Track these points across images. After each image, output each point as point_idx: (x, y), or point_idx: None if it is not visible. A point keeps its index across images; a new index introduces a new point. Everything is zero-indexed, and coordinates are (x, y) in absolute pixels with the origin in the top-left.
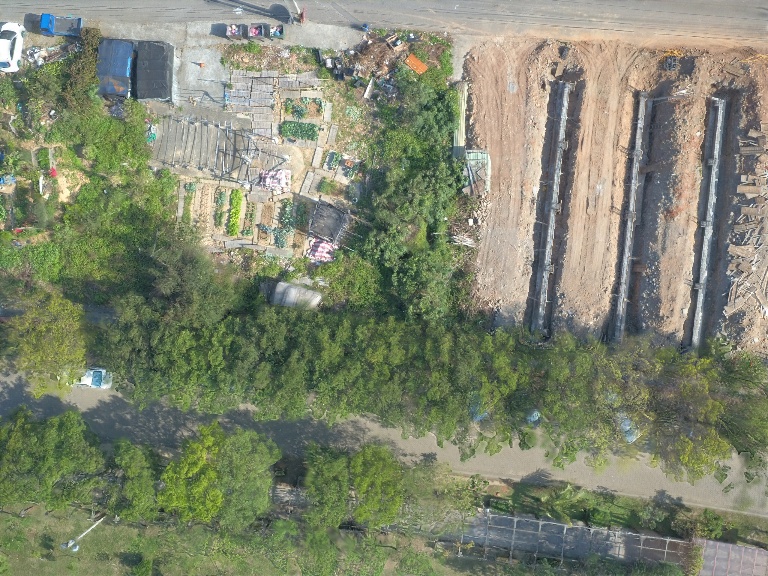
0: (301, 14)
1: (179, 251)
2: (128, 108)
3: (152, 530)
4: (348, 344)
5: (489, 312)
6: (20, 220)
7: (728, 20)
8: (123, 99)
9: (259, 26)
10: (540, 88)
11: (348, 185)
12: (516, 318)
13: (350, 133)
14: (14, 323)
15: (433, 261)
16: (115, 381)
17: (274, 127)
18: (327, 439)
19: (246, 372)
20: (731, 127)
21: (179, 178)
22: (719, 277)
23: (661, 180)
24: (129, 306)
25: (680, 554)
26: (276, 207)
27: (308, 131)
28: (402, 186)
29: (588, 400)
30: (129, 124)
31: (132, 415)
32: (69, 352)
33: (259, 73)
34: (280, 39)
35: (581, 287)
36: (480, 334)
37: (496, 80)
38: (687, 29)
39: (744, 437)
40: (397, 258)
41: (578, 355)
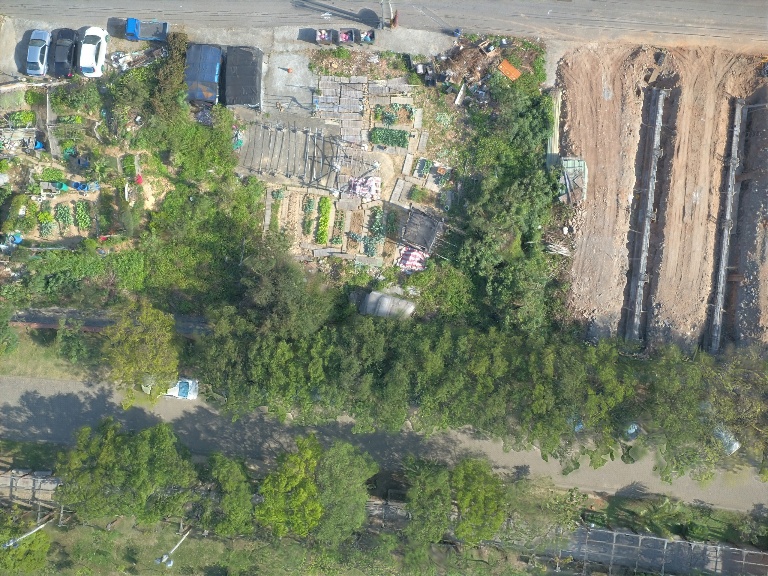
0: (393, 19)
1: (274, 260)
2: (217, 114)
3: (238, 544)
4: (448, 355)
5: (583, 322)
6: (104, 228)
7: None
8: (210, 105)
9: (349, 31)
10: (635, 95)
11: (439, 193)
12: (611, 328)
13: (441, 140)
14: (105, 333)
15: (529, 270)
16: (200, 392)
17: (363, 134)
18: (417, 451)
19: (347, 384)
20: None
21: (266, 185)
22: None
23: (759, 188)
24: (223, 316)
25: None
26: (366, 215)
27: (399, 138)
28: (497, 194)
29: (701, 413)
30: (216, 130)
31: (218, 426)
32: (163, 363)
33: (348, 79)
34: (369, 44)
35: (677, 297)
36: (581, 345)
37: (591, 86)
38: None
39: None
40: (492, 267)
41: (686, 367)
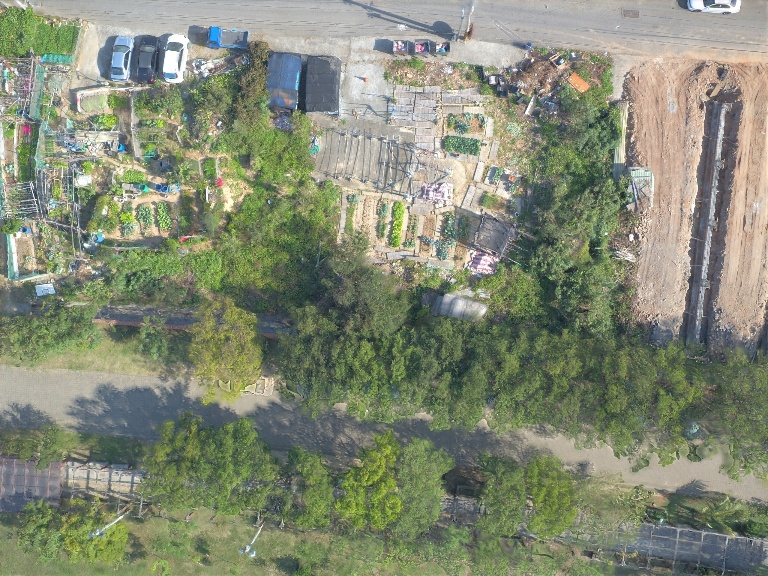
0: (469, 32)
1: (355, 262)
2: (297, 121)
3: (309, 536)
4: (523, 356)
5: (647, 326)
6: (184, 229)
7: None
8: (289, 111)
9: (425, 43)
10: (698, 108)
11: (509, 199)
12: (673, 332)
13: (511, 149)
14: (190, 330)
15: (597, 275)
16: (275, 389)
17: (437, 141)
18: (485, 448)
19: (428, 382)
20: None
21: (341, 190)
22: None
23: None
24: (306, 315)
25: None
26: (438, 220)
27: (471, 146)
28: (566, 201)
29: None
30: (294, 136)
31: (291, 422)
32: (248, 360)
33: (422, 88)
34: (443, 56)
35: (738, 303)
36: (649, 348)
37: (656, 99)
38: None
39: None
40: (562, 272)
41: (753, 370)
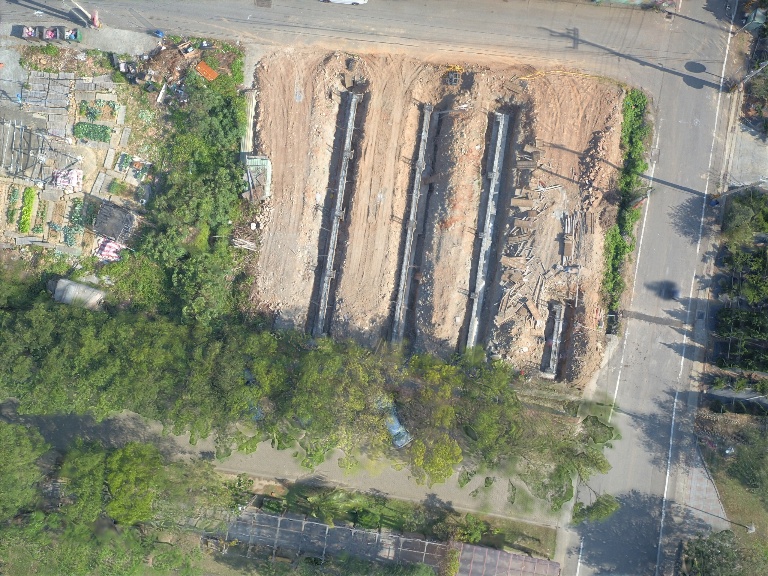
0: (93, 19)
1: None
2: None
3: None
4: (112, 341)
5: (270, 315)
6: None
7: (509, 38)
8: None
9: (55, 29)
10: (327, 98)
11: (138, 187)
12: (296, 321)
13: (142, 136)
14: None
15: (211, 263)
16: None
17: (68, 128)
18: (109, 435)
19: (6, 366)
20: (512, 142)
21: None
22: (495, 287)
23: (439, 191)
24: None
25: (437, 557)
26: (67, 206)
27: (100, 133)
28: (185, 189)
29: (328, 402)
30: None
31: None
32: None
33: (56, 75)
34: (77, 42)
35: (359, 293)
36: (247, 335)
37: (284, 89)
38: (470, 46)
39: (484, 442)
40: (176, 259)
41: (330, 358)
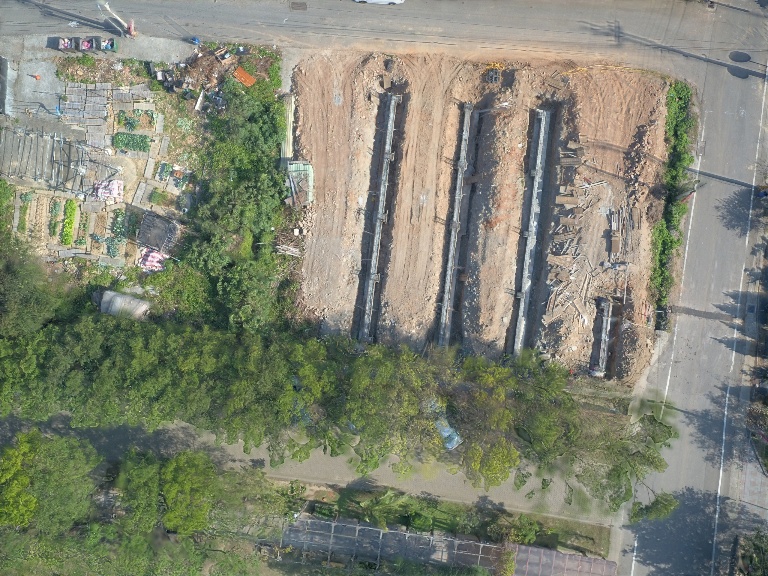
0: (129, 28)
1: (1, 261)
2: None
3: None
4: (162, 352)
5: (315, 320)
6: None
7: (549, 34)
8: None
9: (91, 39)
10: (367, 100)
11: (179, 195)
12: (342, 326)
13: (181, 144)
14: None
15: (256, 270)
16: None
17: (107, 138)
18: (158, 445)
19: (58, 380)
20: (555, 139)
21: (15, 188)
22: (541, 286)
23: (483, 191)
24: None
25: (492, 559)
26: (109, 217)
27: (140, 142)
28: (227, 197)
29: (382, 408)
30: None
31: None
32: None
33: (93, 85)
34: (113, 52)
35: (405, 296)
36: (295, 342)
37: (322, 92)
38: (509, 42)
39: (540, 444)
40: (221, 267)
41: (381, 364)
